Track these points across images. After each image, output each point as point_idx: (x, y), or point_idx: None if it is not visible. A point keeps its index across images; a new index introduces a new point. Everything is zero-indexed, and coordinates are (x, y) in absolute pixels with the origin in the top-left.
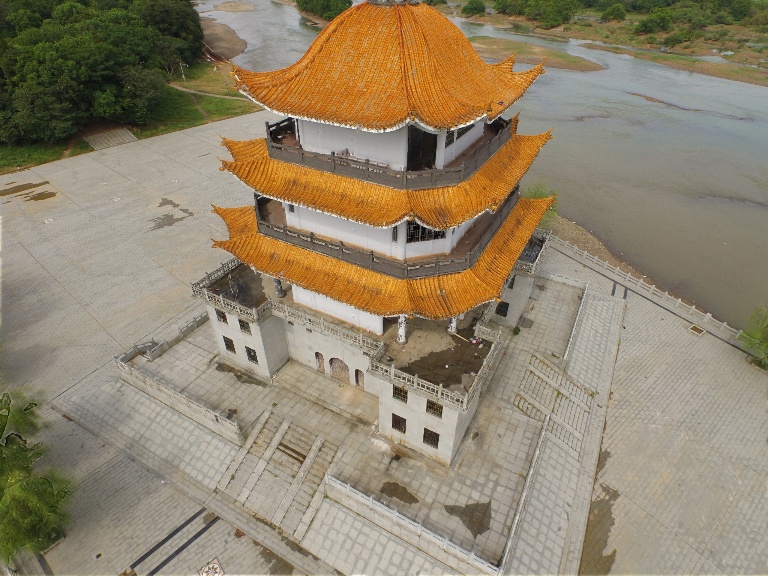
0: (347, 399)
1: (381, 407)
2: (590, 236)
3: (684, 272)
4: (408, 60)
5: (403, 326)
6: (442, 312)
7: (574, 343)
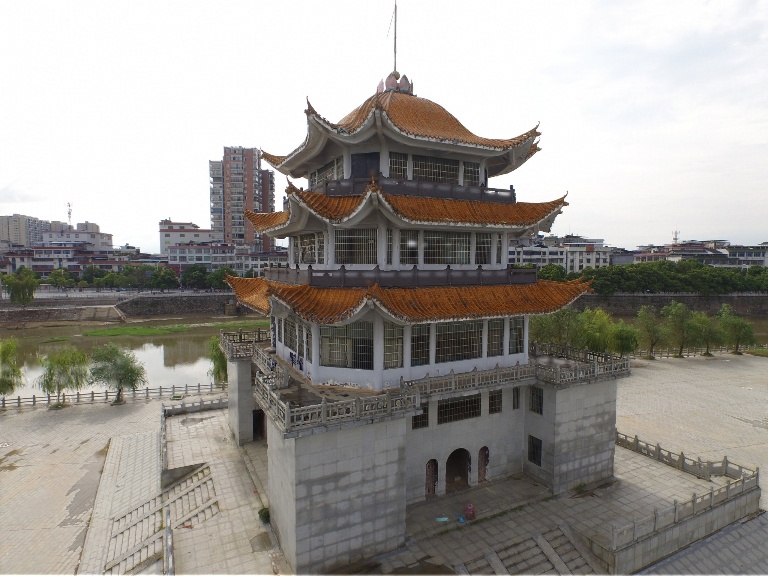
0: None
1: None
2: None
3: None
4: None
5: None
6: None
7: None
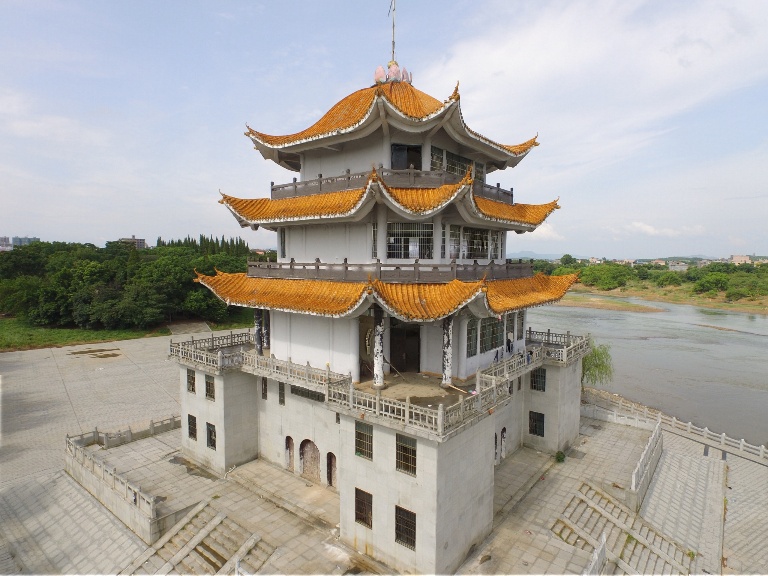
0: (310, 498)
1: (342, 480)
2: None
3: None
4: (394, 100)
5: (379, 360)
6: (417, 313)
7: (651, 488)
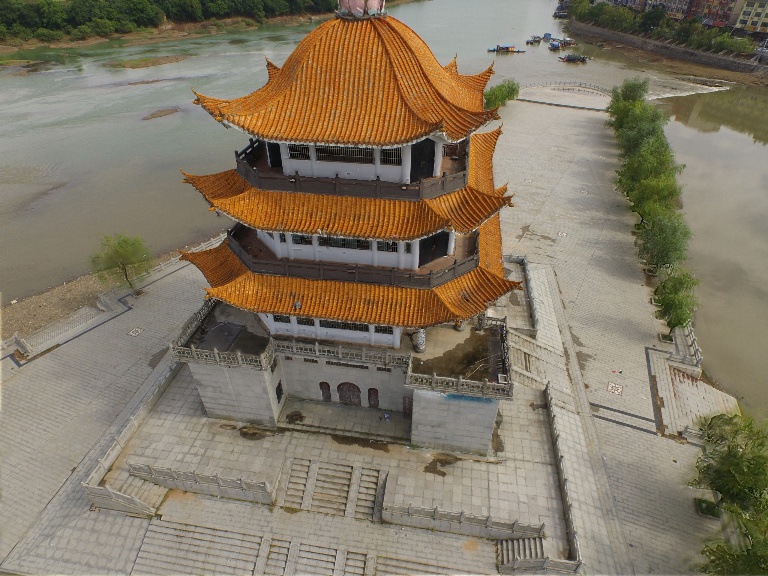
0: None
1: None
2: (104, 272)
3: (177, 230)
4: None
5: None
6: None
7: None
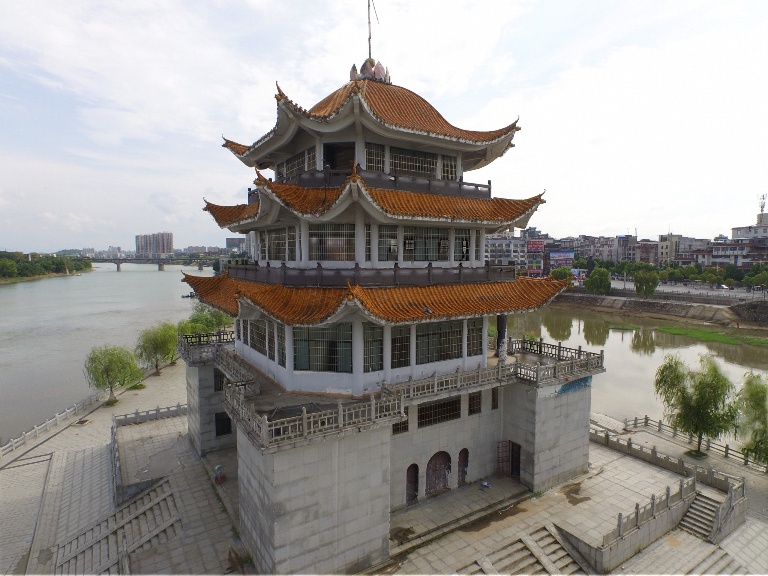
0: None
1: None
2: None
3: None
4: None
5: None
6: None
7: None
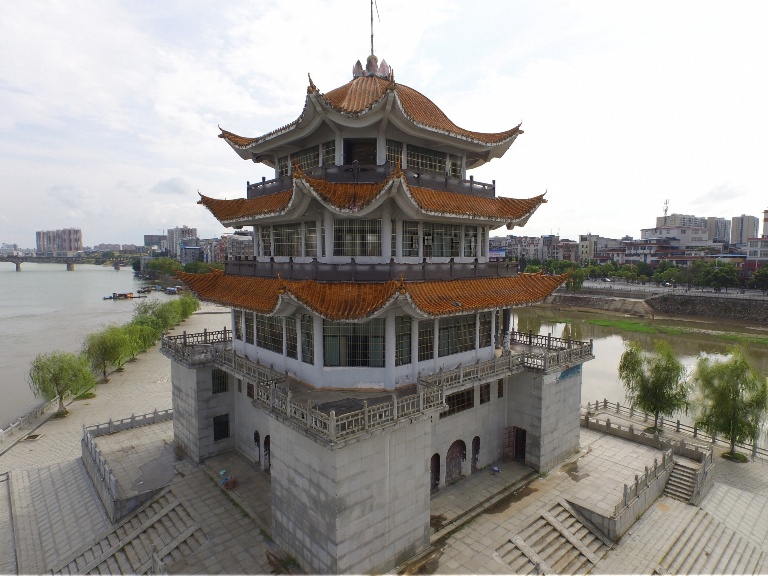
0: None
1: None
2: None
3: None
4: None
5: None
6: None
7: None
